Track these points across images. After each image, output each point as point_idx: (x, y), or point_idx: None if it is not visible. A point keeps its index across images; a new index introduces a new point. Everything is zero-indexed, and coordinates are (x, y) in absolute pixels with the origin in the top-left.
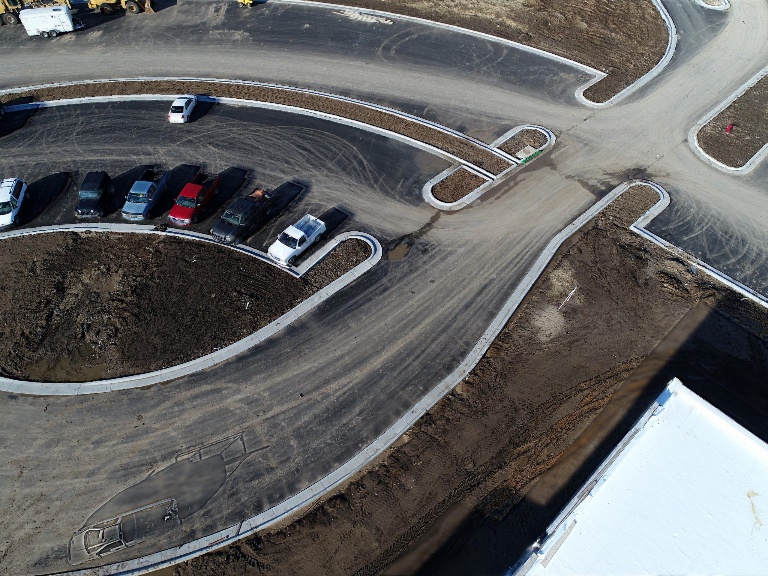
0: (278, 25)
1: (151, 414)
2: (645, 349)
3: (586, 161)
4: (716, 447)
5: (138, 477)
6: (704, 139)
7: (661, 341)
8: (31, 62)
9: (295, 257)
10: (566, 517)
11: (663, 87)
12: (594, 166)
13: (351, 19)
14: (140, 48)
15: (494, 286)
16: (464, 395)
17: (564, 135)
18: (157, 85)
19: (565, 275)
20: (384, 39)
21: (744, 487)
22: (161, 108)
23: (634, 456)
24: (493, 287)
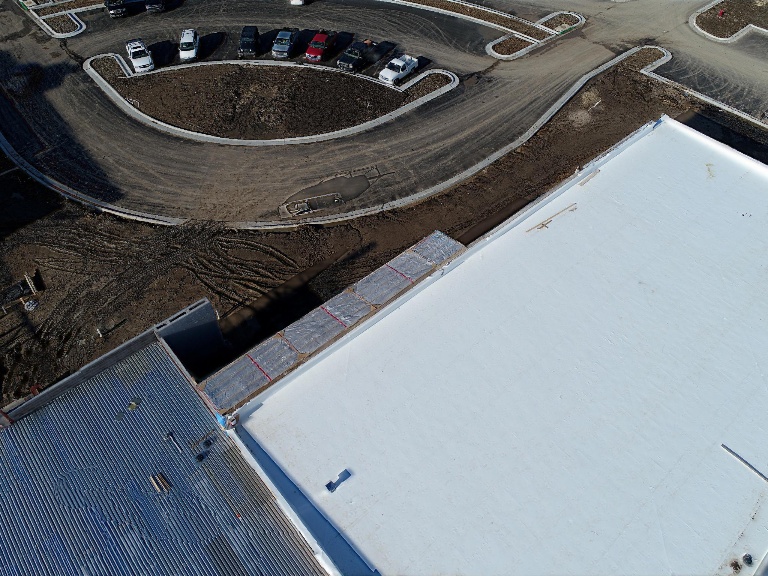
0: None
1: (314, 156)
2: None
3: (609, 34)
4: (689, 145)
5: (313, 183)
6: (701, 21)
7: None
8: None
9: (398, 80)
10: (594, 161)
11: None
12: (615, 36)
13: None
14: None
15: (541, 100)
16: (523, 152)
17: (592, 18)
18: None
19: (592, 94)
20: None
21: (704, 162)
22: None
23: (637, 147)
24: (540, 101)
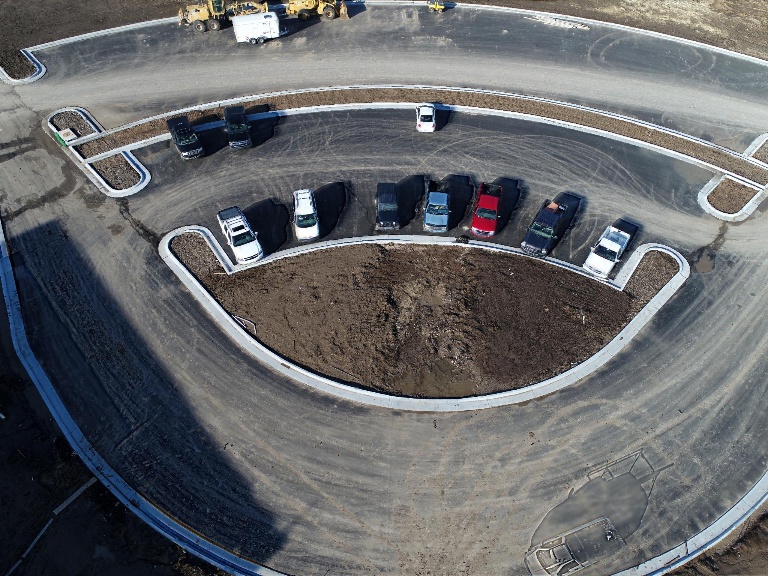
0: (477, 31)
1: (541, 431)
2: None
3: None
4: None
5: (560, 496)
6: None
7: None
8: (250, 69)
9: None
10: None
11: None
12: None
13: (546, 25)
14: (351, 55)
15: None
16: None
17: None
18: (386, 93)
19: None
20: (588, 45)
21: None
22: (400, 116)
23: None
24: None
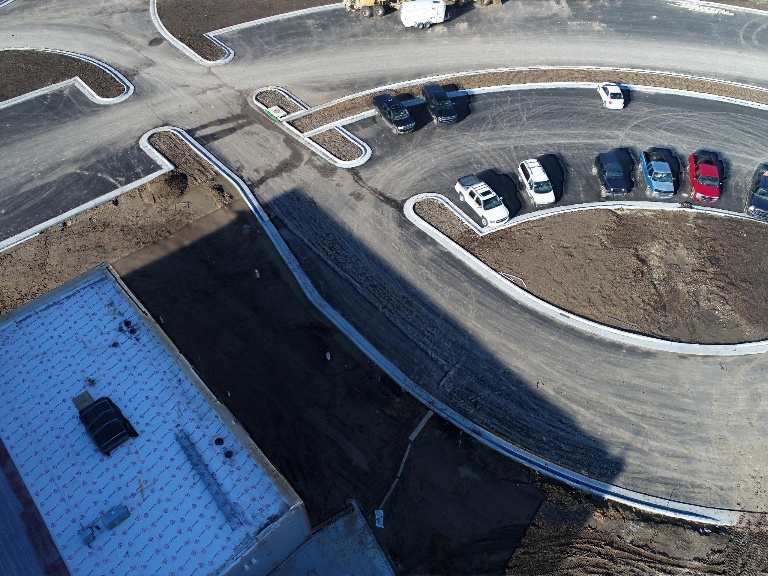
0: (627, 16)
1: None
2: None
3: None
4: None
5: None
6: None
7: None
8: (425, 52)
9: None
10: None
11: None
12: None
13: (691, 10)
14: (516, 39)
15: None
16: None
17: None
18: (562, 73)
19: None
20: (738, 29)
21: None
22: (584, 95)
23: None
24: None
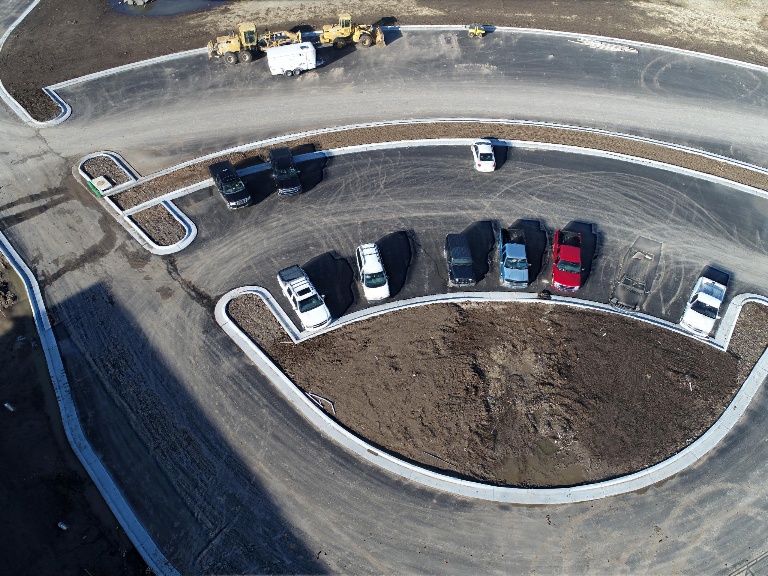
0: (521, 57)
1: (667, 524)
2: None
3: None
4: None
5: None
6: None
7: None
8: (288, 104)
9: None
10: None
11: None
12: None
13: (593, 48)
14: (393, 86)
15: None
16: None
17: None
18: (436, 128)
19: None
20: (640, 70)
21: None
22: (455, 154)
23: None
24: None
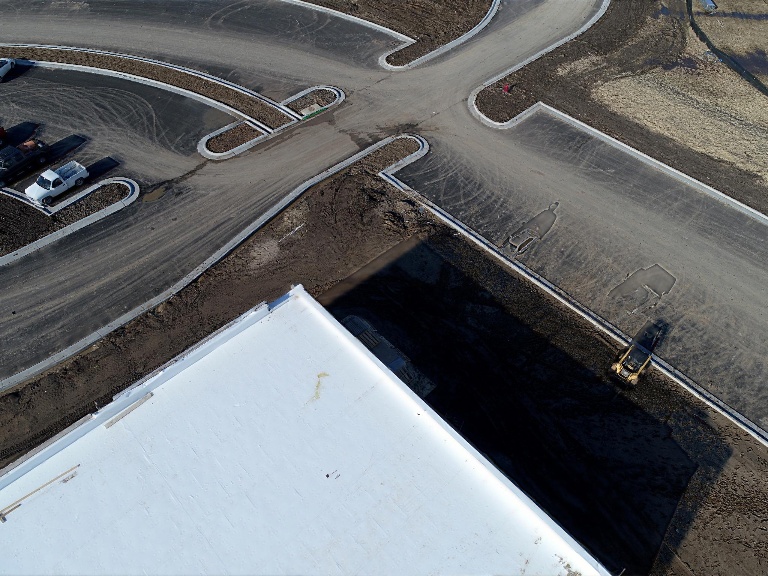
0: None
1: None
2: (343, 275)
3: (364, 117)
4: (310, 339)
5: None
6: (482, 98)
7: (360, 268)
8: None
9: (52, 198)
10: (133, 387)
11: (465, 52)
12: (370, 122)
13: None
14: None
15: (230, 223)
16: (161, 312)
17: (354, 95)
18: None
19: (298, 214)
20: (217, 9)
21: (318, 369)
22: None
23: (232, 345)
24: (229, 224)
